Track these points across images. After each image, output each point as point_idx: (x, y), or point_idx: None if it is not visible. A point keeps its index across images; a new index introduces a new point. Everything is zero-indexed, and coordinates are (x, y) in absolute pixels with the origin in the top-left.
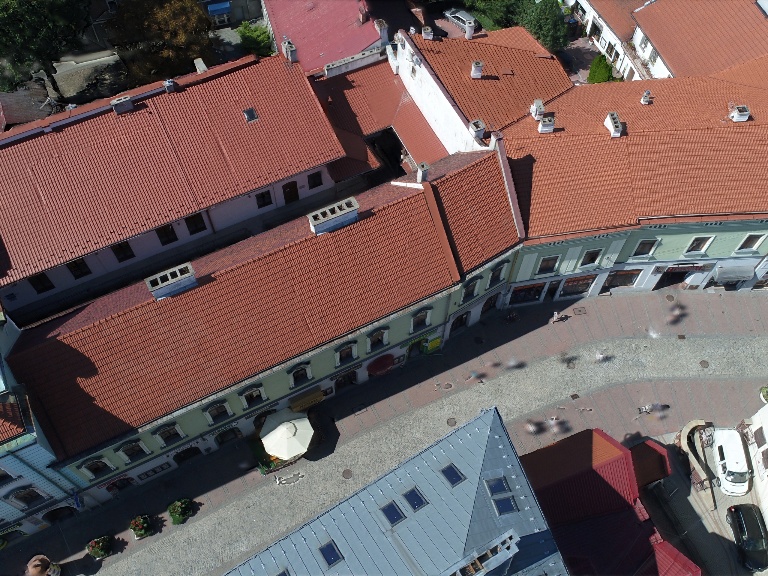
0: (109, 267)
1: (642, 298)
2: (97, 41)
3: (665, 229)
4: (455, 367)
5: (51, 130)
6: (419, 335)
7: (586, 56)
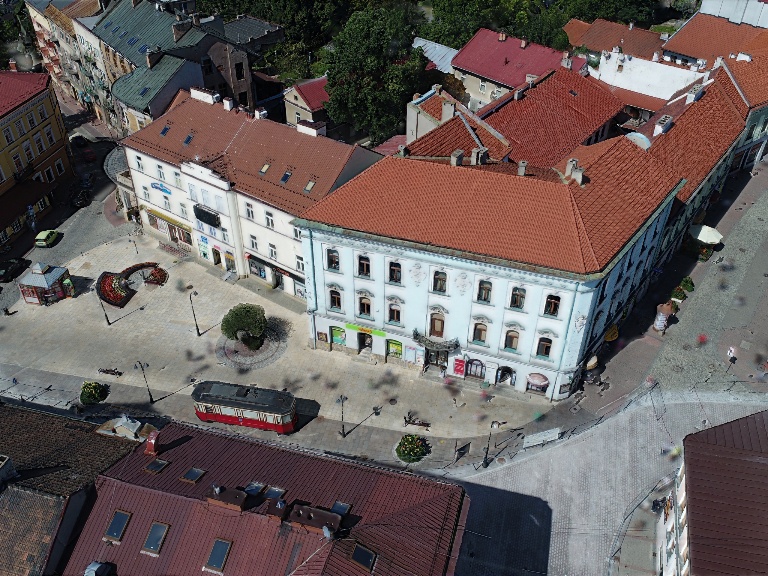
0: None
1: None
2: None
3: None
4: (734, 202)
5: (494, 111)
6: None
7: None
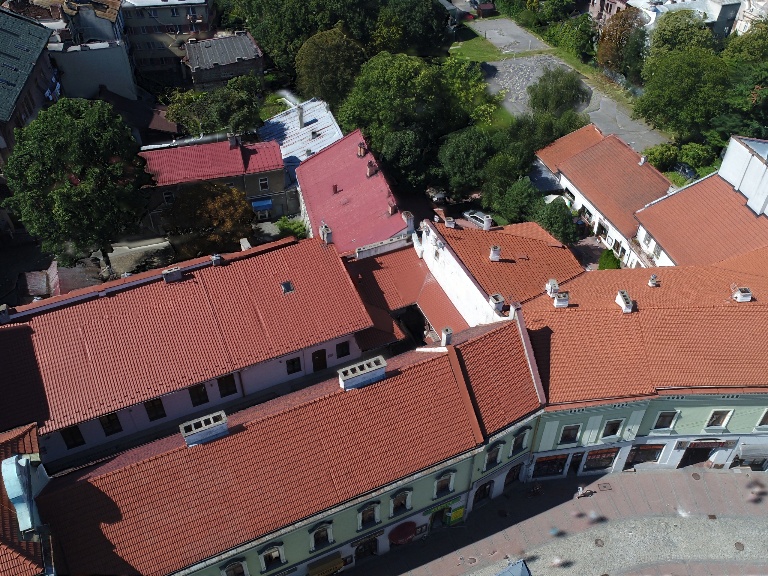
0: (140, 426)
1: (667, 476)
2: (152, 228)
3: (683, 401)
4: (479, 541)
5: (105, 295)
6: (442, 502)
7: (595, 252)
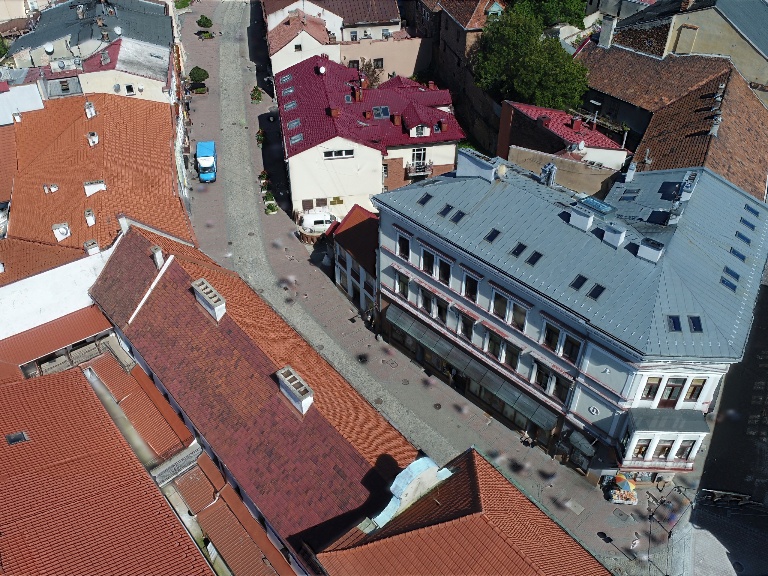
0: None
1: None
2: None
3: None
4: None
5: None
6: None
7: None
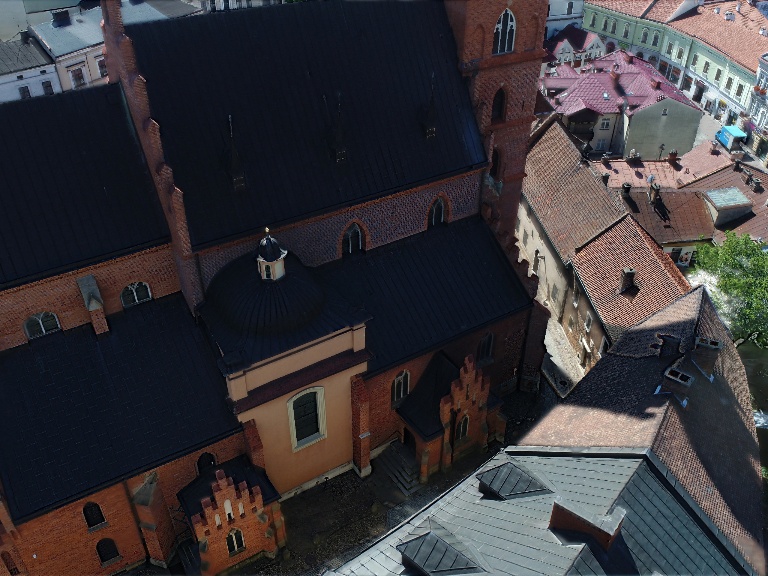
0: None
1: None
2: None
3: None
4: None
5: None
6: None
7: None
